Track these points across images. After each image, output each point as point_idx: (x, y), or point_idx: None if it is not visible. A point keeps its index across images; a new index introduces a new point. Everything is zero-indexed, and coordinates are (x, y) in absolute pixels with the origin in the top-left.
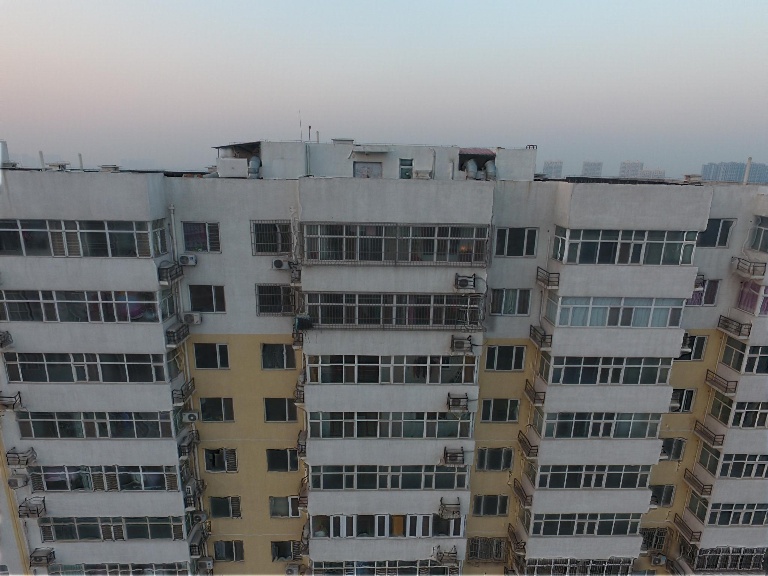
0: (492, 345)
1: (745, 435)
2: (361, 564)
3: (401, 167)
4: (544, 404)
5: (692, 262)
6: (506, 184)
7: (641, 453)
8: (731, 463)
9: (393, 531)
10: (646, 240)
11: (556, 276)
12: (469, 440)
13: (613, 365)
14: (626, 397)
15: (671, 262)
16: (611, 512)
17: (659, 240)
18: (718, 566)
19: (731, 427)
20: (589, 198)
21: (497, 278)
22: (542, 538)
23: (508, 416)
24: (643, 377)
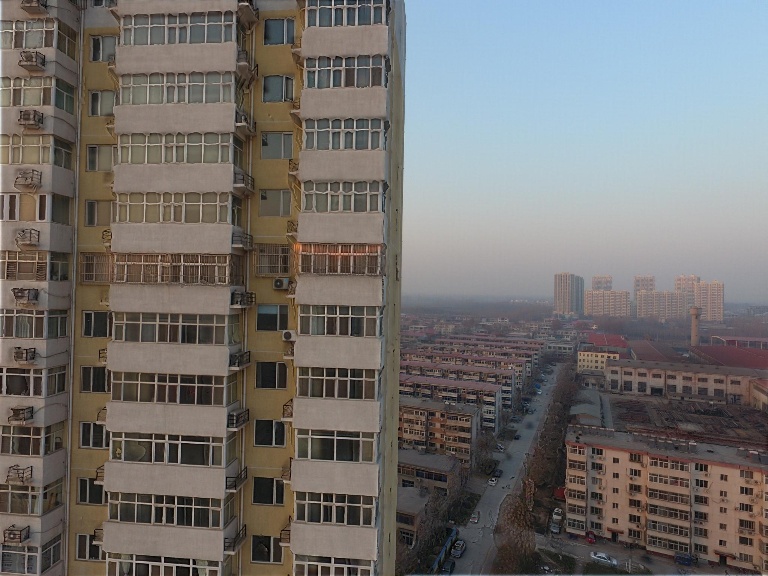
0: (95, 35)
1: (320, 95)
2: None
3: None
4: (116, 65)
5: None
6: None
7: (215, 117)
8: (315, 132)
9: None
10: None
11: None
12: (49, 106)
13: (178, 24)
14: (192, 55)
15: None
16: (195, 191)
17: None
18: (327, 269)
19: (306, 88)
20: None
21: None
22: (126, 223)
23: None
24: (209, 36)
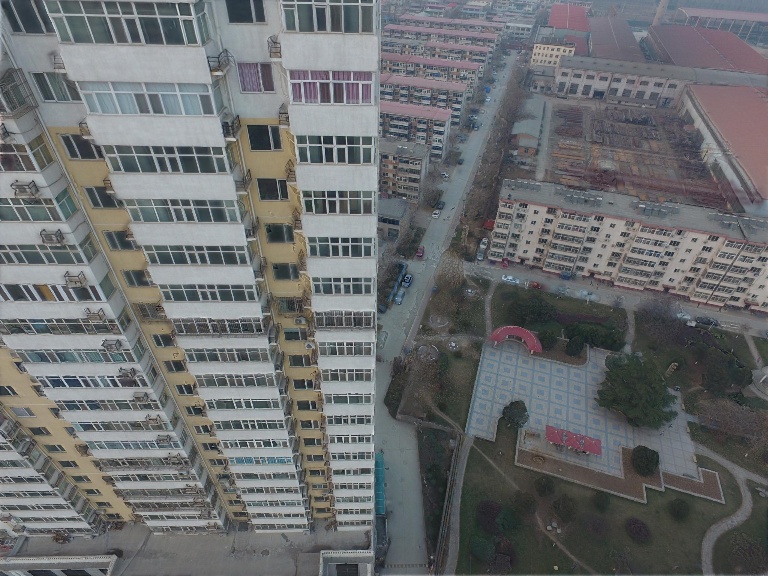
0: (63, 134)
1: (318, 220)
2: (33, 321)
3: None
4: (115, 191)
5: (199, 41)
6: None
7: (227, 235)
8: (317, 245)
9: (46, 297)
10: (137, 14)
11: (59, 57)
12: (62, 223)
13: (166, 154)
14: (191, 185)
15: (177, 41)
16: (224, 283)
17: (151, 14)
18: (335, 324)
19: (305, 213)
20: None
21: (29, 60)
22: (174, 303)
23: (116, 203)
24: (202, 166)
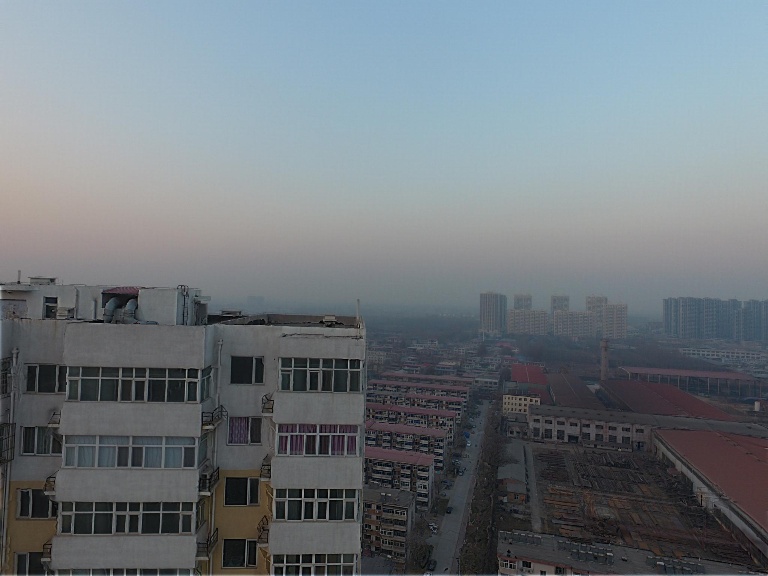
0: (24, 489)
1: None
2: None
3: (47, 304)
4: (52, 559)
5: (198, 399)
6: (32, 323)
7: None
8: None
9: None
10: (148, 377)
11: (59, 413)
12: None
13: (128, 511)
14: (145, 549)
15: (177, 399)
16: None
17: (161, 377)
18: None
19: None
20: (82, 337)
21: (27, 415)
22: None
23: (47, 574)
24: (165, 525)
